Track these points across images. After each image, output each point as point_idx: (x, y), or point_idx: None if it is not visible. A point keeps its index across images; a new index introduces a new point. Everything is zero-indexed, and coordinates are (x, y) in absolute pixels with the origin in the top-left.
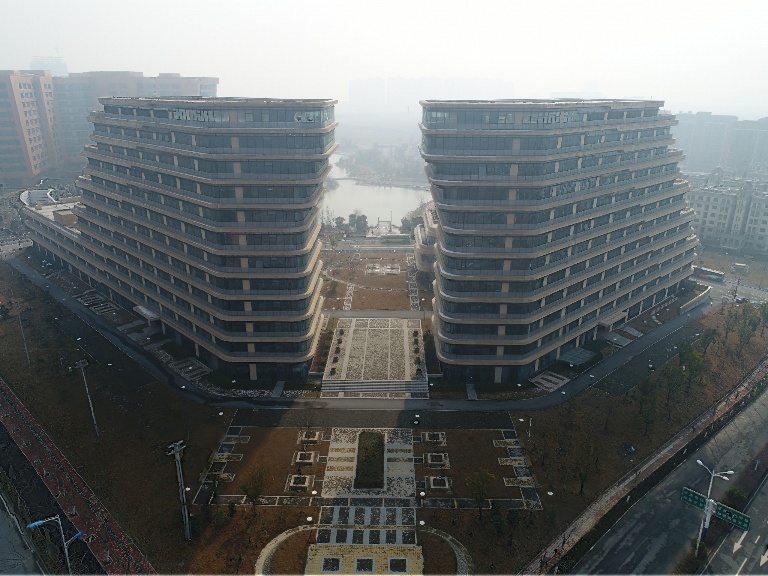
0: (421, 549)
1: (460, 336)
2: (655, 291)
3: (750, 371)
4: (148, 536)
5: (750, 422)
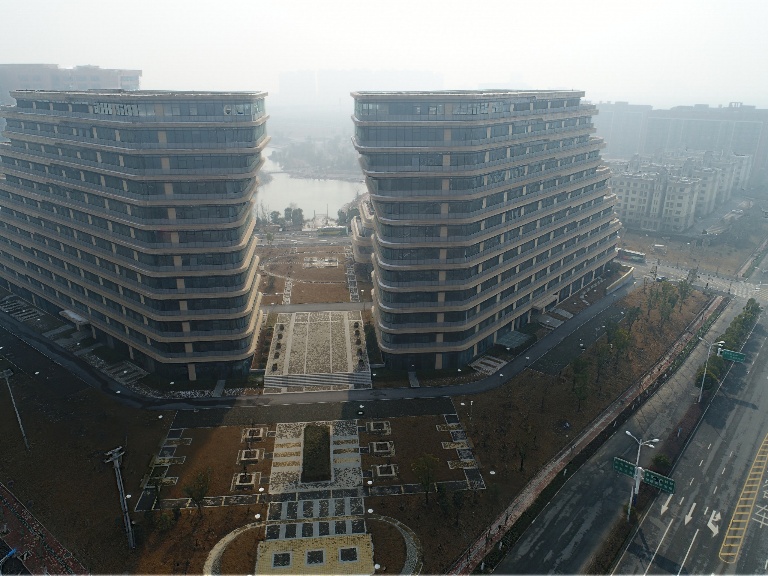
0: (371, 537)
1: (400, 325)
2: (583, 274)
3: (671, 345)
4: (88, 548)
5: (672, 393)
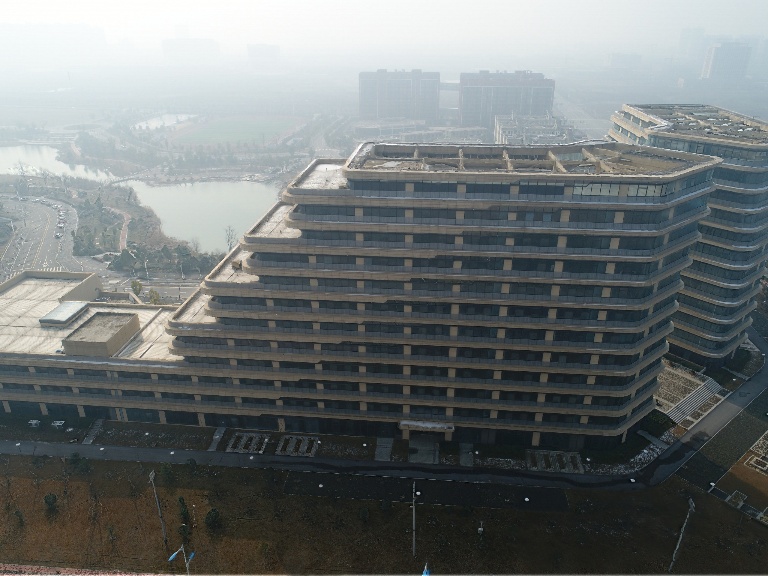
0: None
1: (728, 332)
2: None
3: None
4: None
5: None
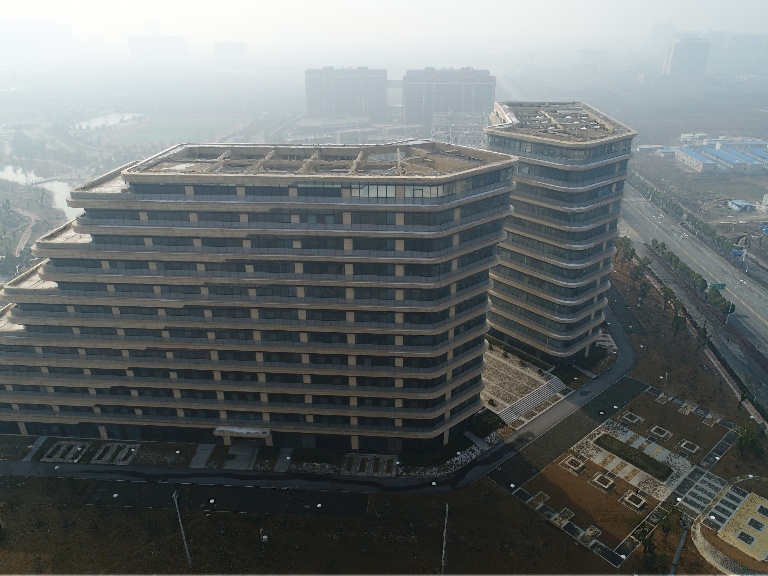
0: (755, 494)
1: (573, 331)
2: None
3: None
4: None
5: None
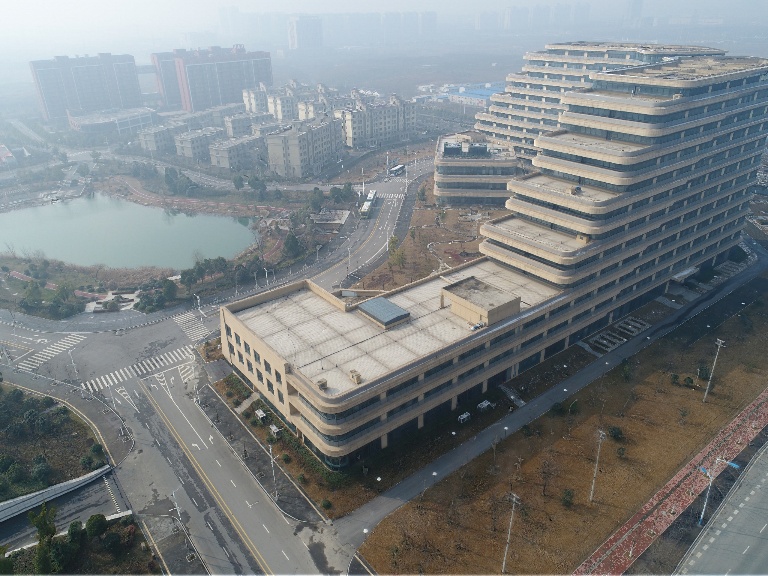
0: None
1: None
2: None
3: None
4: None
5: None
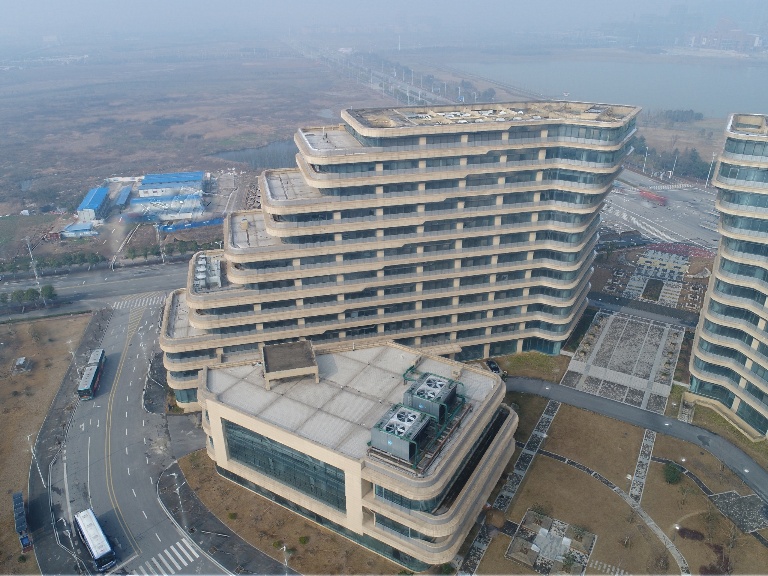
0: None
1: None
2: None
3: None
4: None
5: None
